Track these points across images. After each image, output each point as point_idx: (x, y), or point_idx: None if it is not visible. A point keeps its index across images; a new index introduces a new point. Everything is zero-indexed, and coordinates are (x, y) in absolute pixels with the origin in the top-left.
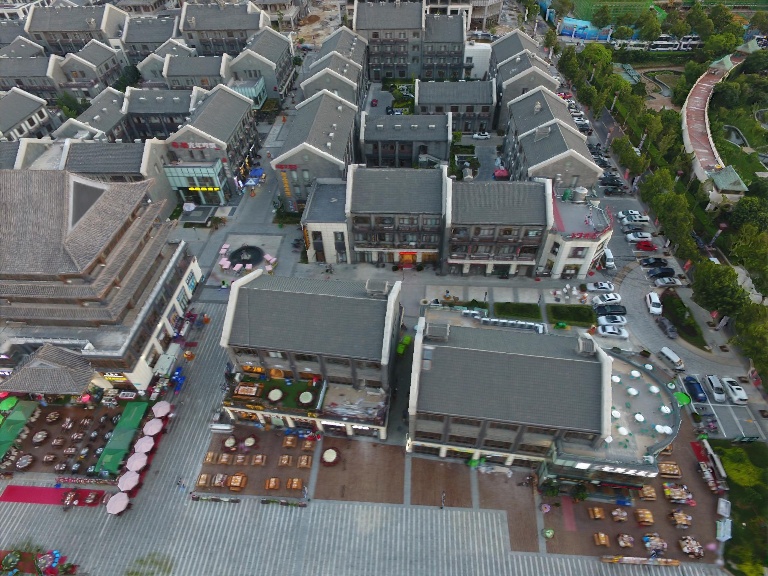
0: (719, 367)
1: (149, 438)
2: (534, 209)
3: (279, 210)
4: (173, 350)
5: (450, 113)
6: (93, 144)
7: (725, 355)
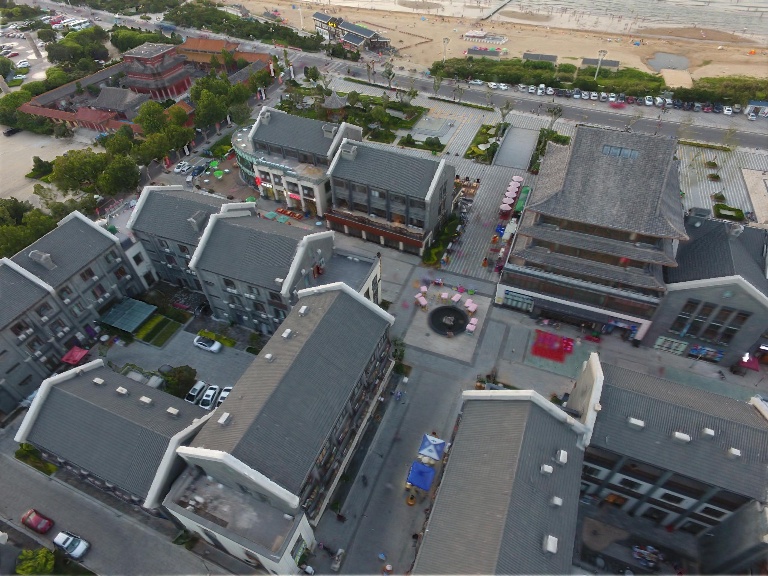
0: (170, 178)
1: (508, 196)
2: (180, 192)
3: (398, 367)
4: (506, 235)
5: (49, 380)
6: (722, 417)
7: (157, 181)
